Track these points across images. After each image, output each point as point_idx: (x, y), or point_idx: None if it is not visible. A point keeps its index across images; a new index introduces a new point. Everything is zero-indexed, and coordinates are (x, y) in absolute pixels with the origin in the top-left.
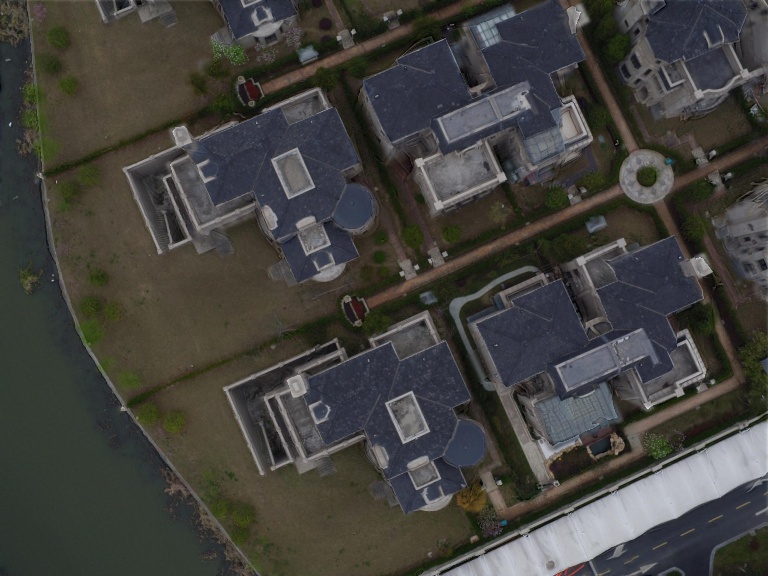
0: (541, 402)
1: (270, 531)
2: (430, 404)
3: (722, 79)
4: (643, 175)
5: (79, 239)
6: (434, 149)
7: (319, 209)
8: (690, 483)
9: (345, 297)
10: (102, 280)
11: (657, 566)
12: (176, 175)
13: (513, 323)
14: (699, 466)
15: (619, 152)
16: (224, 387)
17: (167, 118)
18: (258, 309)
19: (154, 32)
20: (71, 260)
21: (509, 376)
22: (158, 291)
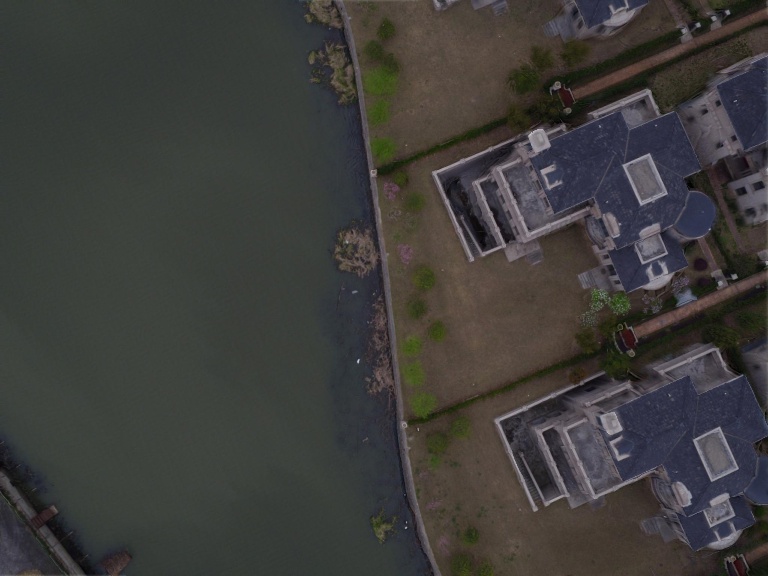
0: None
1: None
2: None
3: None
4: None
5: (444, 491)
6: None
7: (735, 486)
8: None
9: (731, 558)
10: (474, 538)
11: None
12: (571, 440)
13: None
14: None
15: None
16: None
17: (536, 364)
18: (633, 566)
19: (519, 270)
20: (435, 513)
21: None
22: (529, 547)
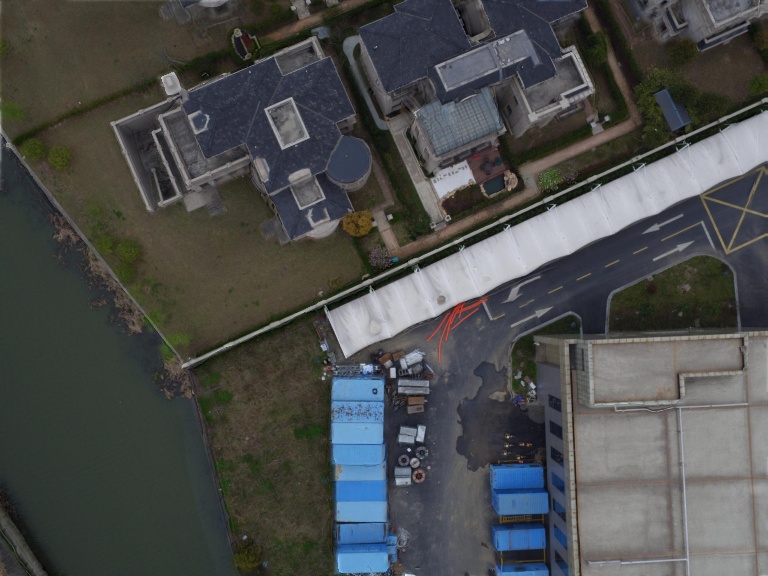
0: (422, 108)
1: (158, 270)
2: (311, 114)
3: None
4: None
5: None
6: None
7: None
8: (583, 218)
9: (235, 30)
10: None
11: (553, 310)
12: None
13: (393, 25)
14: (592, 202)
15: None
16: (111, 122)
17: None
18: (148, 47)
19: None
20: None
21: (389, 79)
22: (46, 28)
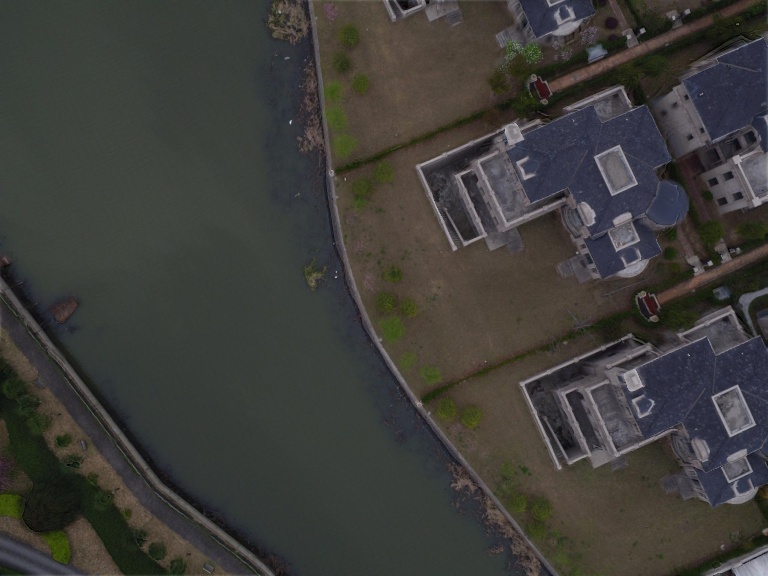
0: None
1: (564, 525)
2: (752, 398)
3: None
4: None
5: (369, 236)
6: (751, 146)
7: (636, 206)
8: None
9: (641, 293)
10: (397, 276)
11: None
12: (484, 172)
13: None
14: None
15: None
16: (520, 382)
17: (456, 116)
18: (549, 305)
19: (440, 31)
20: (361, 257)
21: None
22: (450, 287)
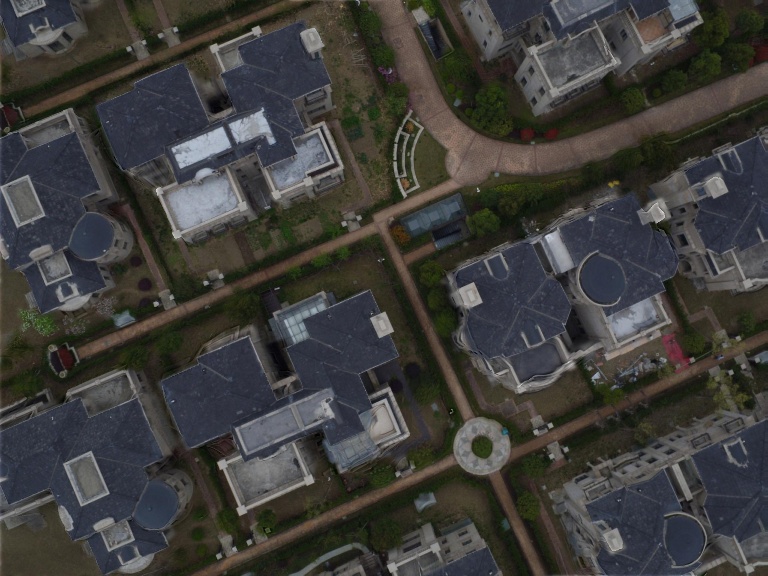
0: None
1: None
2: None
3: (550, 367)
4: (479, 445)
5: None
6: None
7: (117, 511)
8: None
9: None
10: None
11: None
12: None
13: None
14: None
15: (453, 422)
16: None
17: None
18: None
19: None
20: None
21: None
22: None
